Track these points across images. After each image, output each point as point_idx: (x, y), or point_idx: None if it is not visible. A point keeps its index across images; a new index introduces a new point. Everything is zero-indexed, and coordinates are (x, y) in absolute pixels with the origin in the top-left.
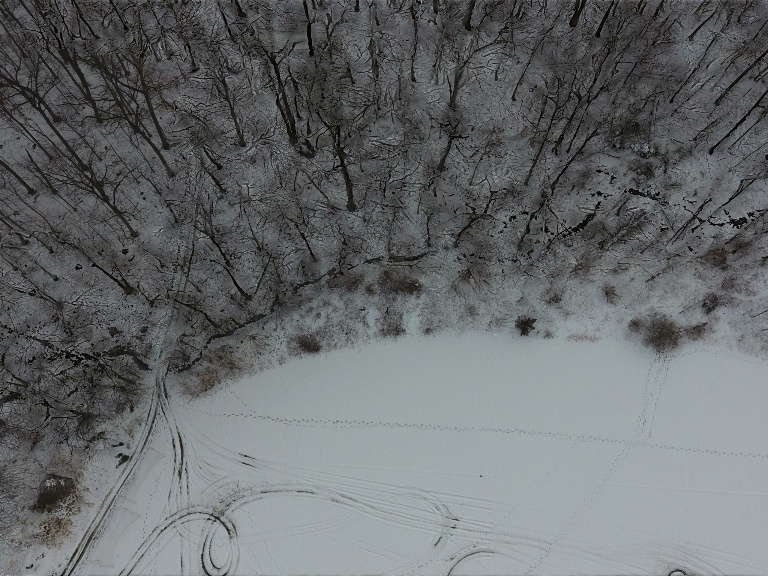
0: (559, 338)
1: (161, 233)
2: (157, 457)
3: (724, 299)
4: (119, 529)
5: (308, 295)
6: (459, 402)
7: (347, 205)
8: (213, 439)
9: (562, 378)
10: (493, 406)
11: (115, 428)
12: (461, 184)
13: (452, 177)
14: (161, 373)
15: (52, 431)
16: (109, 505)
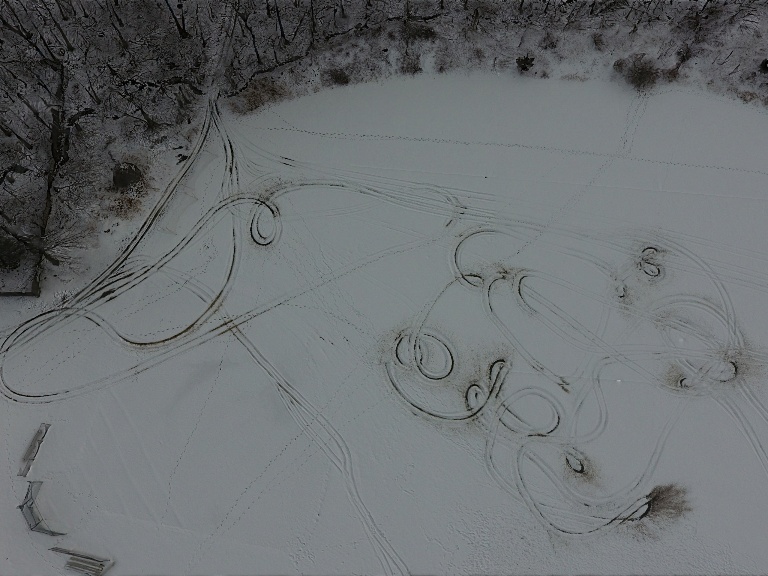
0: (554, 78)
1: None
2: (211, 157)
3: (696, 50)
4: (181, 208)
5: (338, 40)
6: (468, 123)
7: None
8: (258, 145)
9: (556, 108)
10: (497, 127)
11: (175, 135)
12: None
13: None
14: (213, 96)
15: (122, 136)
16: (172, 191)
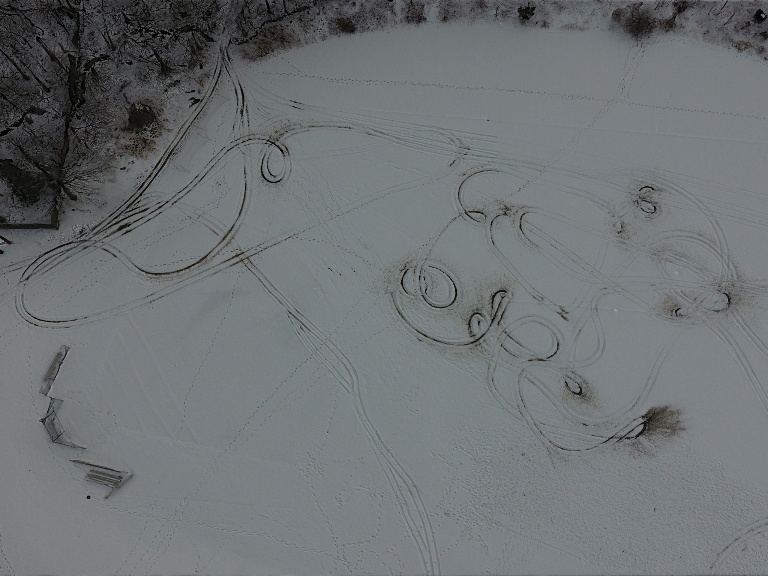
0: (554, 28)
1: None
2: (223, 100)
3: (693, 1)
4: (193, 148)
5: None
6: (470, 70)
7: None
8: (268, 90)
9: (556, 56)
10: (499, 73)
11: (188, 79)
12: None
13: None
14: (224, 43)
15: (136, 80)
16: (185, 132)
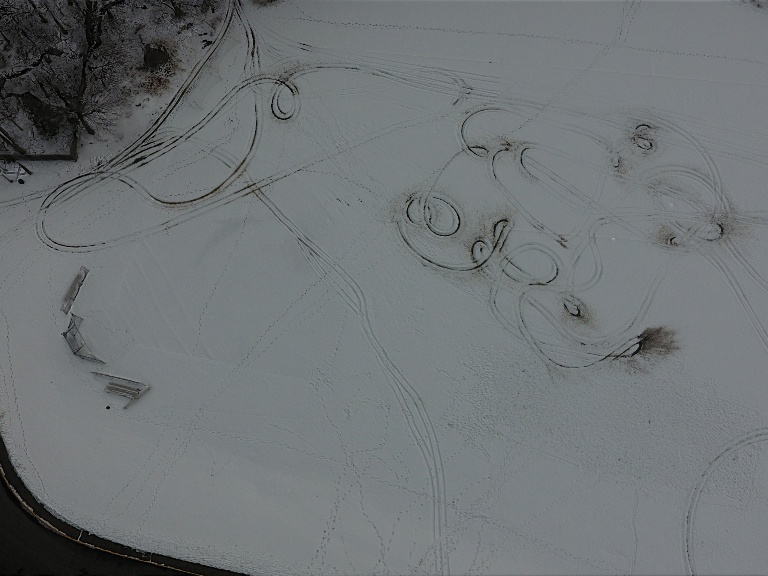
0: None
1: None
2: (234, 43)
3: None
4: (206, 87)
5: None
6: (473, 15)
7: None
8: (278, 33)
9: (556, 3)
10: (500, 19)
11: (201, 22)
12: None
13: None
14: None
15: (151, 23)
16: (198, 72)
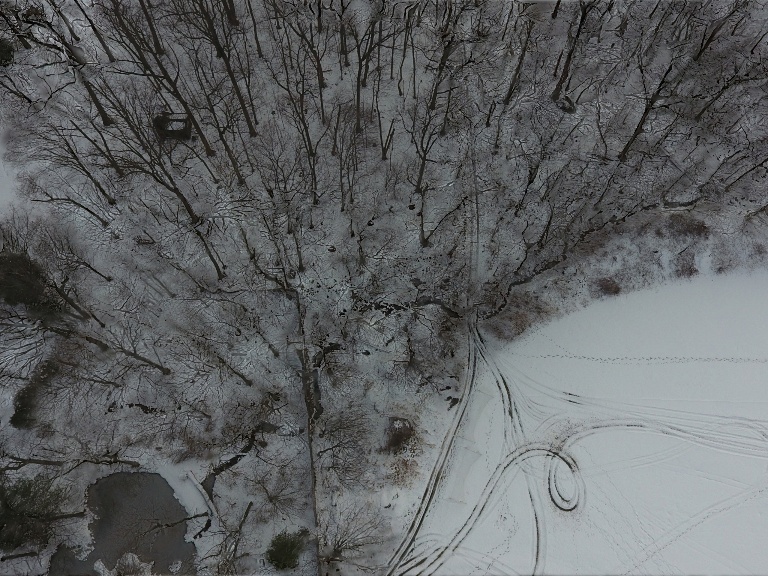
0: None
1: (449, 187)
2: (486, 398)
3: None
4: (464, 468)
5: (599, 241)
6: (763, 336)
7: (619, 155)
8: (535, 379)
9: None
10: None
11: (440, 373)
12: (719, 133)
13: (710, 126)
14: (472, 319)
15: (380, 378)
16: (449, 446)
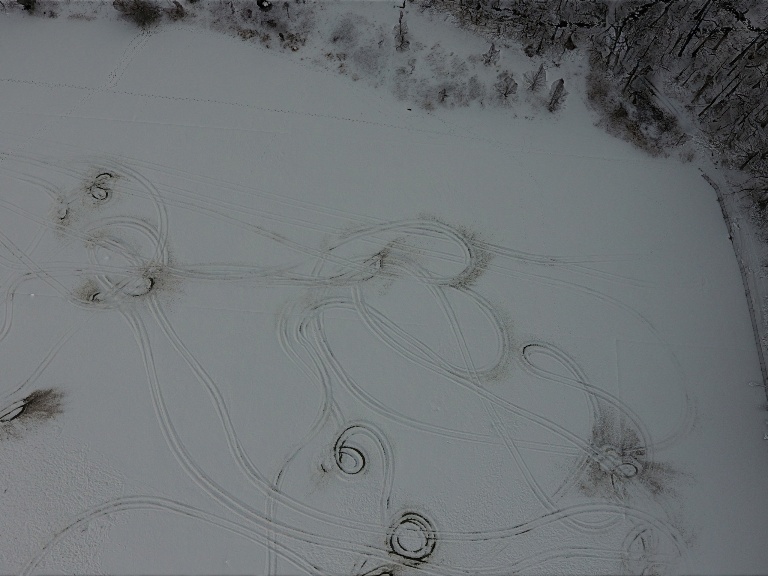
0: (62, 18)
1: None
2: None
3: None
4: None
5: None
6: None
7: None
8: None
9: (56, 45)
10: None
11: None
12: None
13: None
14: None
15: None
16: None
